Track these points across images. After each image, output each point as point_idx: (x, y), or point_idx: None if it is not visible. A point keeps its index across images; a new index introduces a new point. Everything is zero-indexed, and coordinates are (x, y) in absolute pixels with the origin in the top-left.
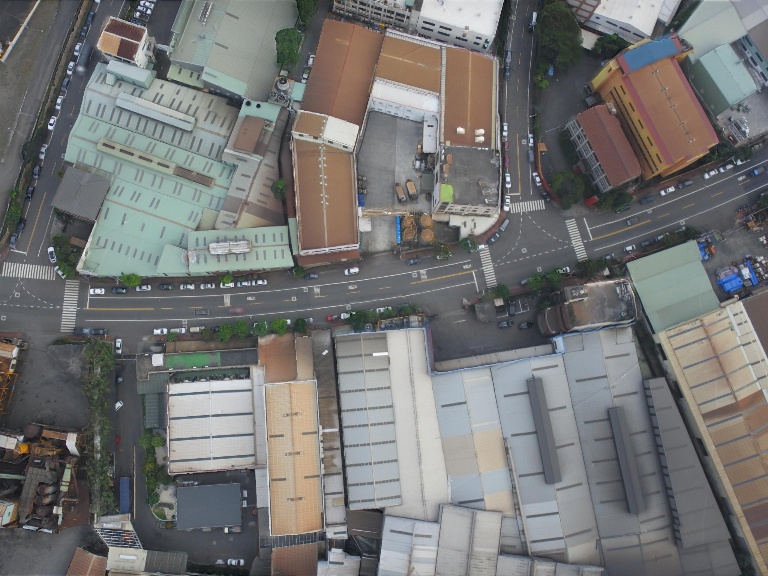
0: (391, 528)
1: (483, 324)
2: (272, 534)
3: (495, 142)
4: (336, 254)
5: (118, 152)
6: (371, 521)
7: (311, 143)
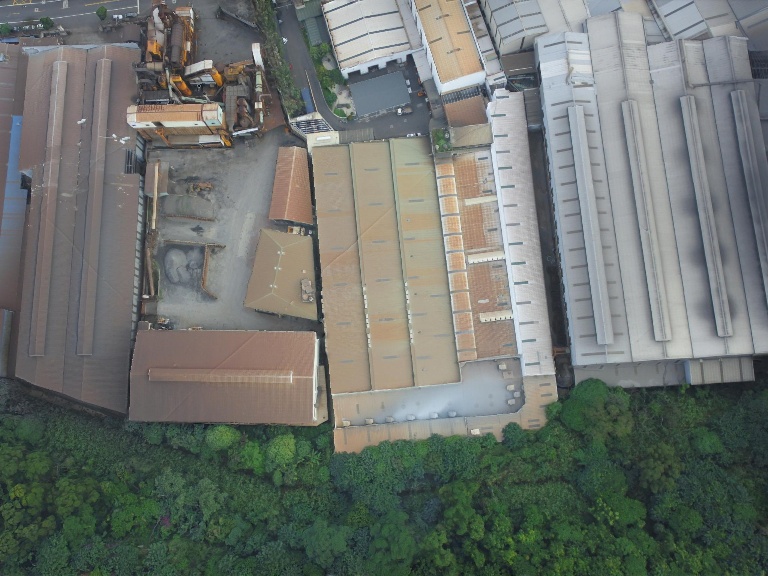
0: (544, 44)
1: None
2: (441, 83)
3: None
4: None
5: None
6: (524, 60)
7: None
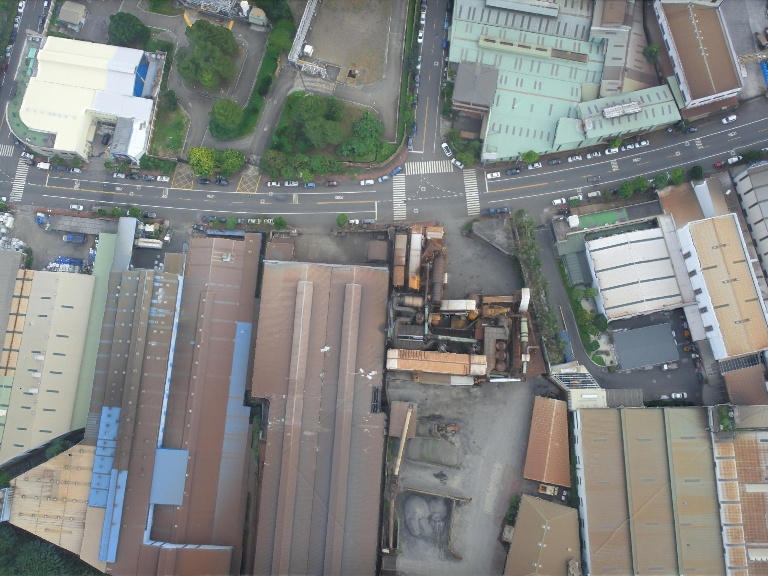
0: None
1: None
2: (727, 355)
3: None
4: (716, 103)
5: (499, 45)
6: None
7: (678, 4)
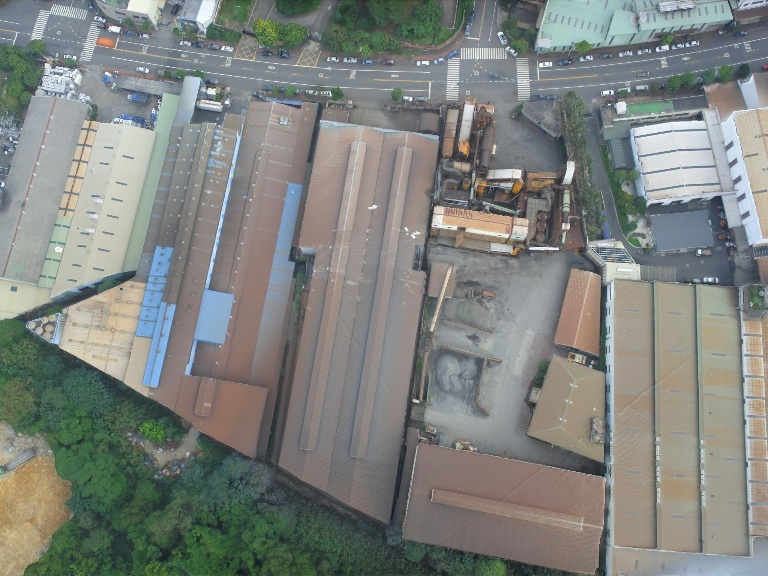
0: None
1: None
2: (762, 238)
3: None
4: None
5: None
6: None
7: None
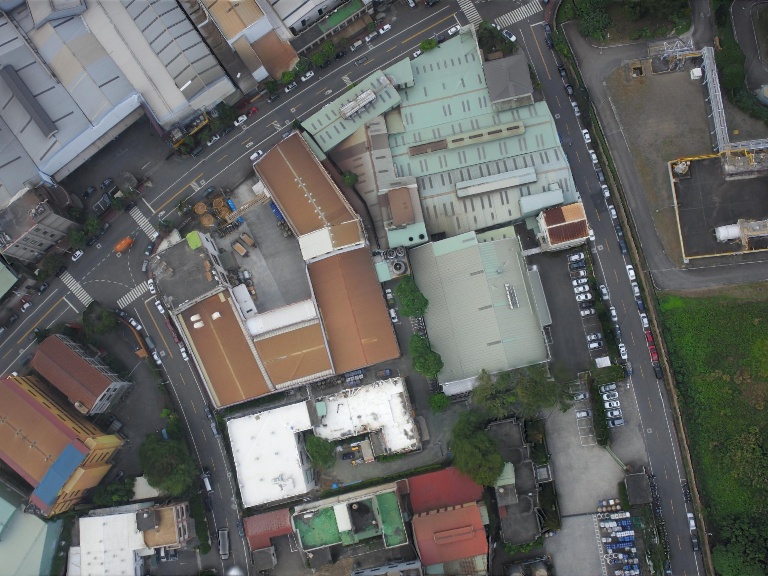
0: None
1: None
2: None
3: (182, 327)
4: None
5: (502, 128)
6: None
7: None
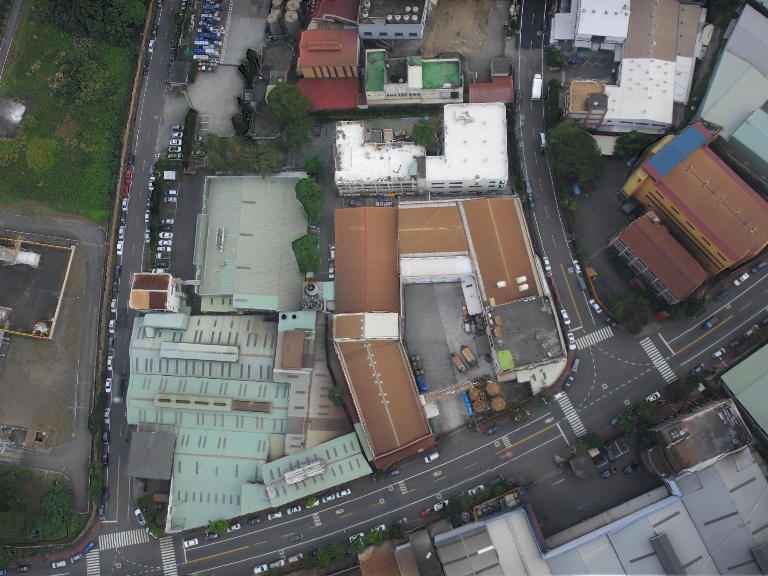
0: None
1: (584, 480)
2: None
3: (540, 284)
4: (411, 447)
5: (175, 404)
6: None
7: (355, 343)
